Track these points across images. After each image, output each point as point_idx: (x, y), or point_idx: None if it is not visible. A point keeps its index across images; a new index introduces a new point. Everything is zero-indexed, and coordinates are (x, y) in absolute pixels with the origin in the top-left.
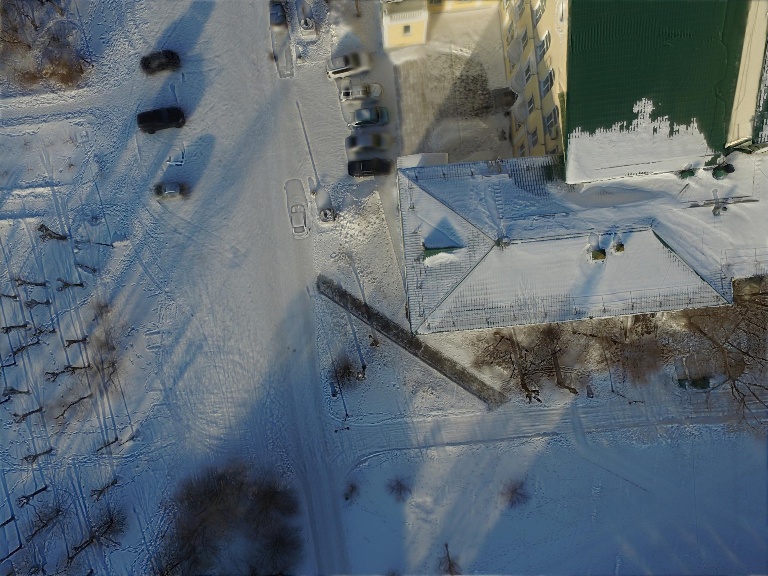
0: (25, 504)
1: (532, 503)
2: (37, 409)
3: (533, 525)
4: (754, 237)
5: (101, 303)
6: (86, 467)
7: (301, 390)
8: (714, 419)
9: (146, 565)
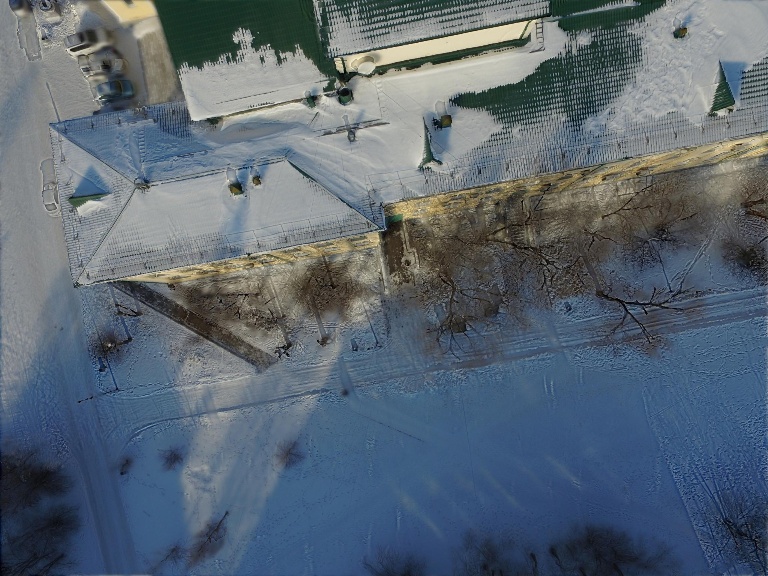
0: None
1: (307, 462)
2: None
3: (310, 485)
4: (393, 160)
5: None
6: None
7: (71, 368)
8: (479, 362)
9: None
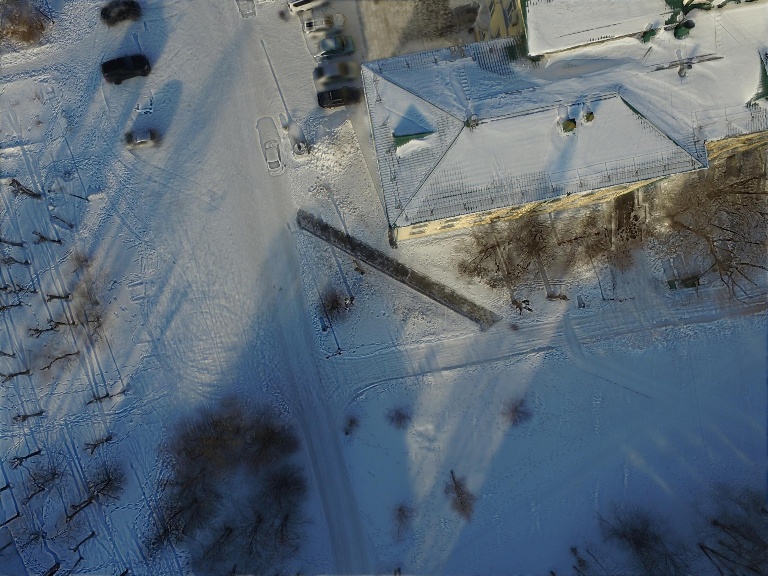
0: (18, 465)
1: (534, 420)
2: (24, 372)
3: (537, 442)
4: (722, 96)
5: (81, 258)
6: (79, 427)
7: (291, 328)
8: (707, 318)
9: (148, 521)
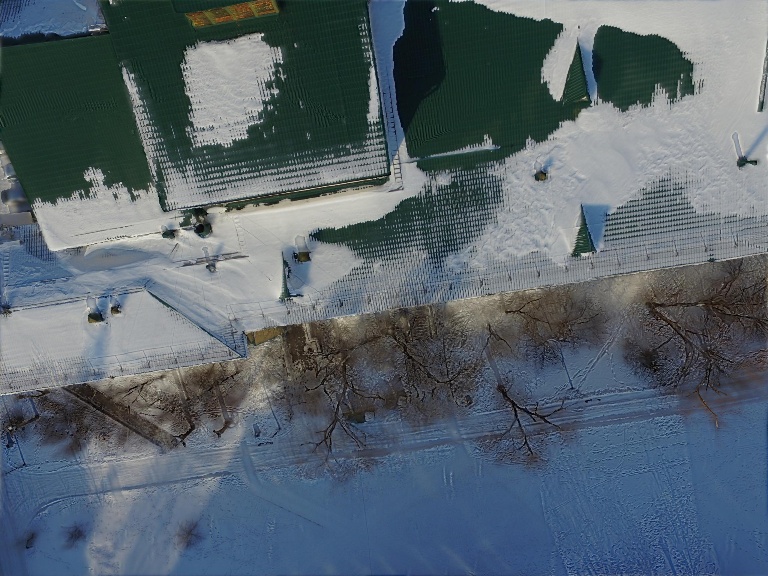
0: None
1: (208, 543)
2: None
3: (211, 564)
4: (254, 291)
5: None
6: None
7: None
8: (380, 451)
9: None
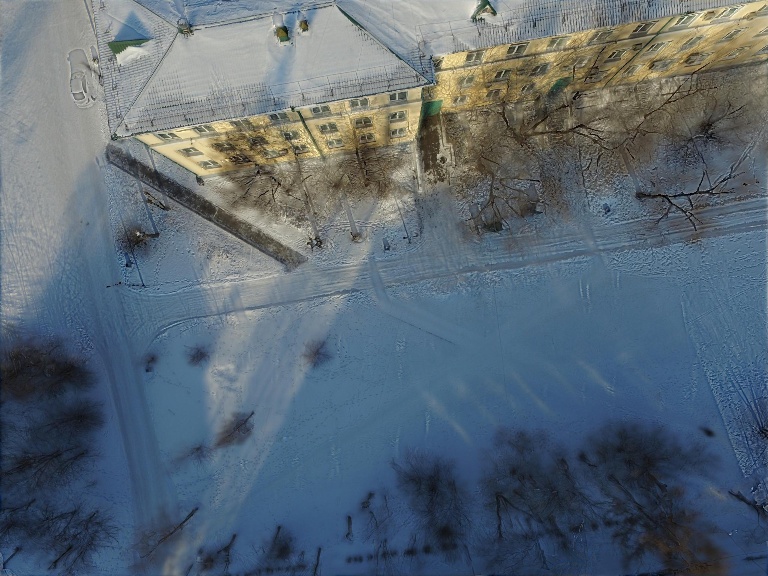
0: None
1: (335, 363)
2: None
3: (338, 386)
4: (445, 9)
5: None
6: None
7: (97, 264)
8: (514, 264)
9: None
